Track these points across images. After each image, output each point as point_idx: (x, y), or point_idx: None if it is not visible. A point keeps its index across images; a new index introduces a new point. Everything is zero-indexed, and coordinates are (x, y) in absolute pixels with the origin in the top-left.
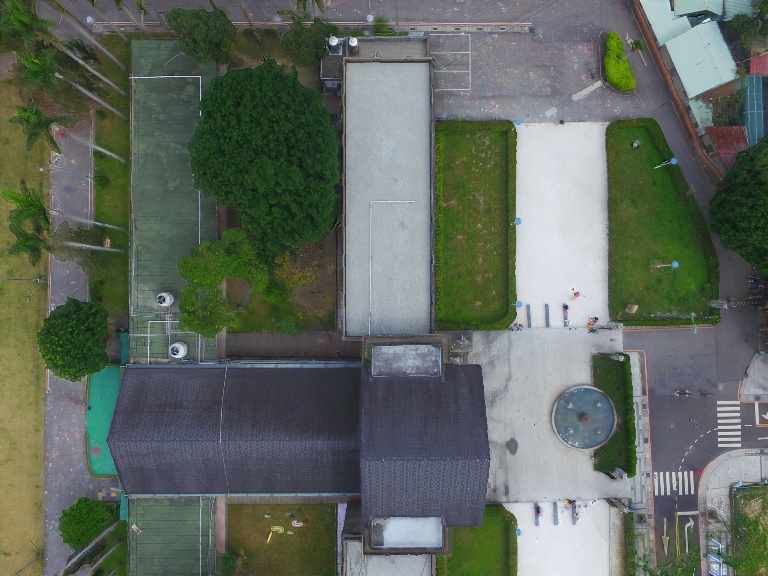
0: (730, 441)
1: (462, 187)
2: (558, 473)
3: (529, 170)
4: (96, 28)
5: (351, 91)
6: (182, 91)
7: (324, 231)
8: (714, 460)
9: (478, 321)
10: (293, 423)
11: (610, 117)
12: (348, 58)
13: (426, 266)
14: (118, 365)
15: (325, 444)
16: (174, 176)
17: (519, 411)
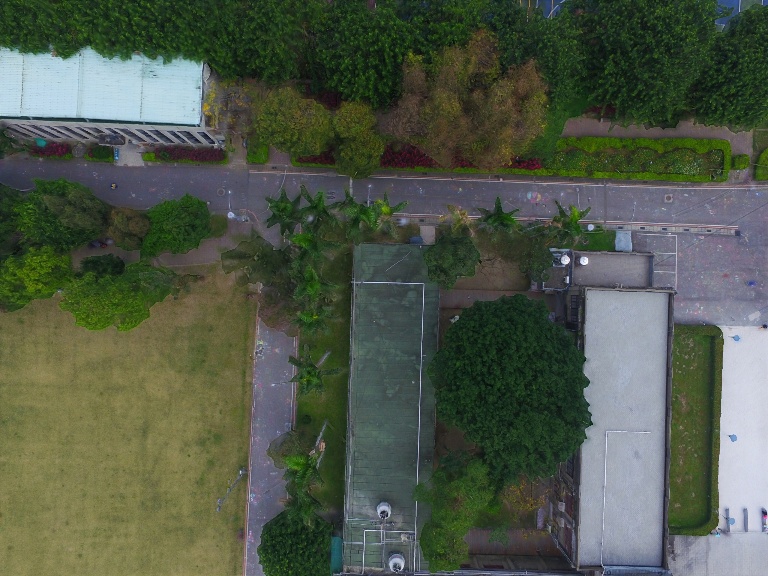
0: None
1: None
2: None
3: (731, 373)
4: None
5: (589, 318)
6: (404, 297)
7: None
8: None
9: (677, 523)
10: None
11: None
12: (591, 288)
13: (659, 497)
14: None
15: None
16: (393, 383)
17: None
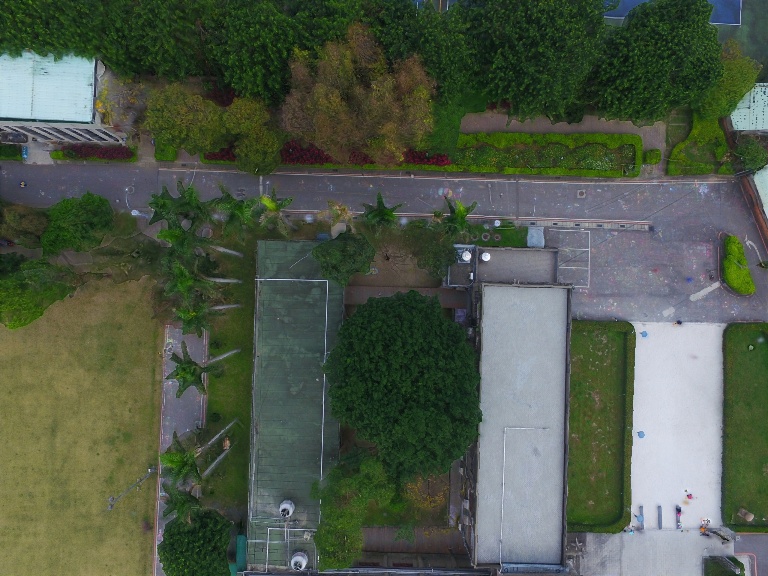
0: None
1: (578, 385)
2: None
3: (645, 369)
4: None
5: (487, 314)
6: (308, 294)
7: None
8: None
9: (591, 521)
10: None
11: (727, 318)
12: (487, 284)
13: (558, 494)
14: (229, 561)
15: None
16: (297, 380)
17: None
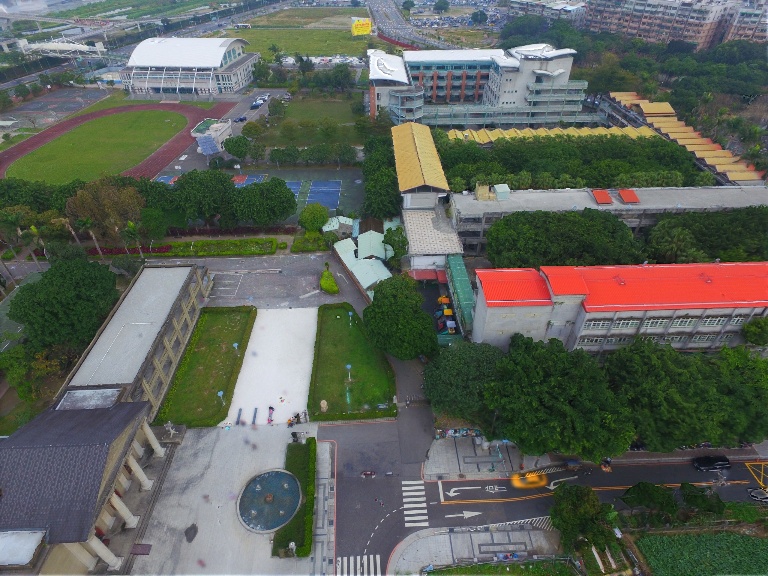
0: (417, 520)
1: (213, 340)
2: (232, 562)
3: (263, 331)
4: (17, 277)
5: (141, 279)
6: None
7: (82, 339)
8: (402, 541)
9: None
10: None
11: None
12: (145, 265)
13: None
14: None
15: None
16: (5, 328)
17: (208, 496)
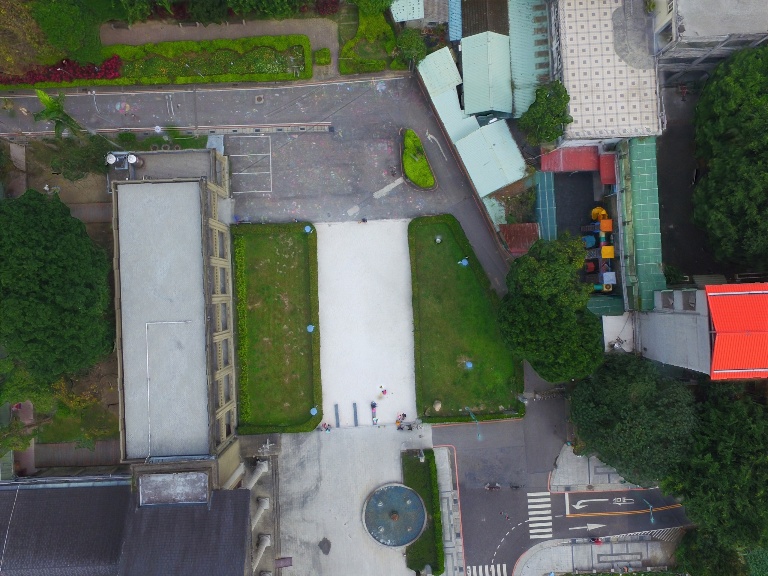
0: (541, 532)
1: (266, 289)
2: (371, 571)
3: (333, 269)
4: None
5: (124, 213)
6: None
7: (100, 355)
8: (526, 552)
9: (287, 422)
10: (76, 548)
11: (412, 213)
12: (116, 181)
13: (204, 386)
14: None
15: (107, 568)
16: None
17: (330, 511)
